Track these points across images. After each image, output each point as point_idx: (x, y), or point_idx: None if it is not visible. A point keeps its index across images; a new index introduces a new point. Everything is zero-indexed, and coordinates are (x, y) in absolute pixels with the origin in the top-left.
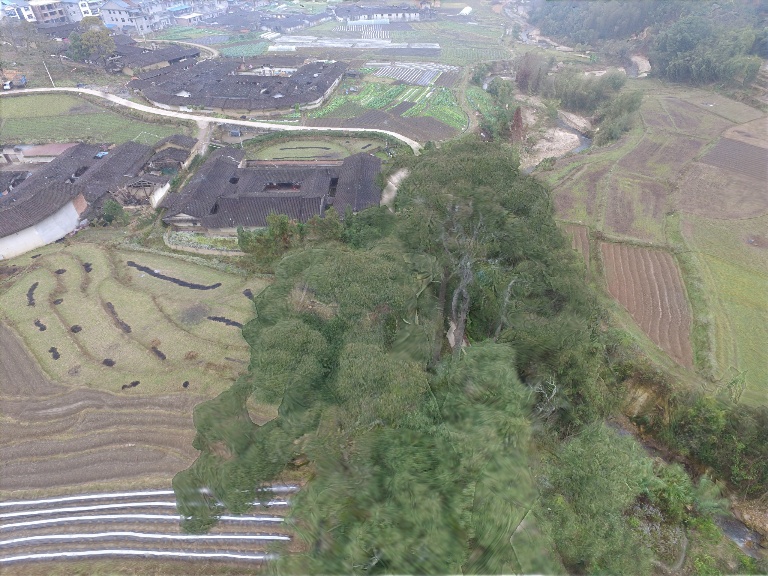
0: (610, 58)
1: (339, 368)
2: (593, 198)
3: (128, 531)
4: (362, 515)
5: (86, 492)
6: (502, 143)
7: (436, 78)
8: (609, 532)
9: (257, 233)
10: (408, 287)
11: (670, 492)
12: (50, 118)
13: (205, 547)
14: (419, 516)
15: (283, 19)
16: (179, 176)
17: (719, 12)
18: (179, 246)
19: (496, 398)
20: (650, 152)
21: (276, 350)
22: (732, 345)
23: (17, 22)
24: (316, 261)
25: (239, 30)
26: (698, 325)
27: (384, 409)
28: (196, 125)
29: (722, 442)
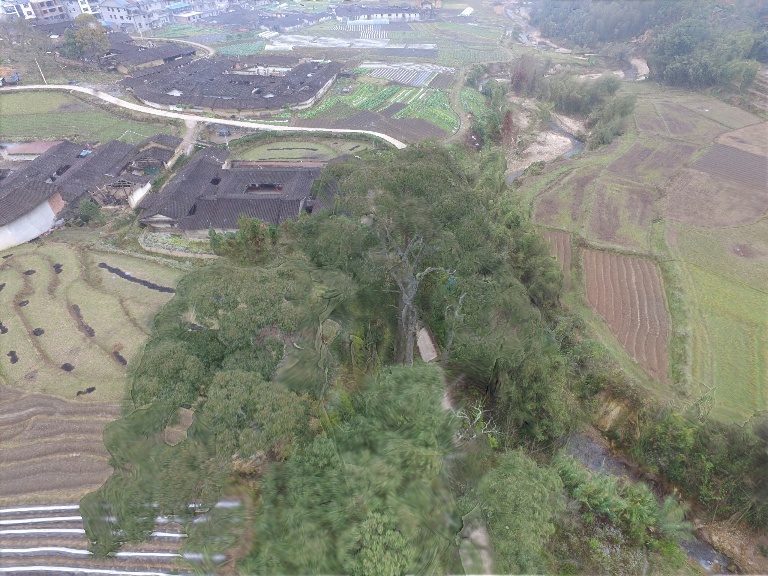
0: (609, 61)
1: (216, 397)
2: (579, 204)
3: (60, 546)
4: (255, 549)
5: (23, 504)
6: (493, 146)
7: (431, 79)
8: (567, 553)
9: (228, 236)
10: (304, 308)
11: (632, 512)
12: (39, 115)
13: (137, 565)
14: (306, 555)
15: (282, 18)
16: (161, 176)
17: (720, 15)
18: (153, 248)
19: (410, 425)
20: (641, 157)
21: (148, 377)
22: (709, 358)
23: (13, 19)
24: (205, 280)
25: (237, 29)
26: (676, 337)
27: (266, 441)
28: (184, 124)
29: (690, 460)
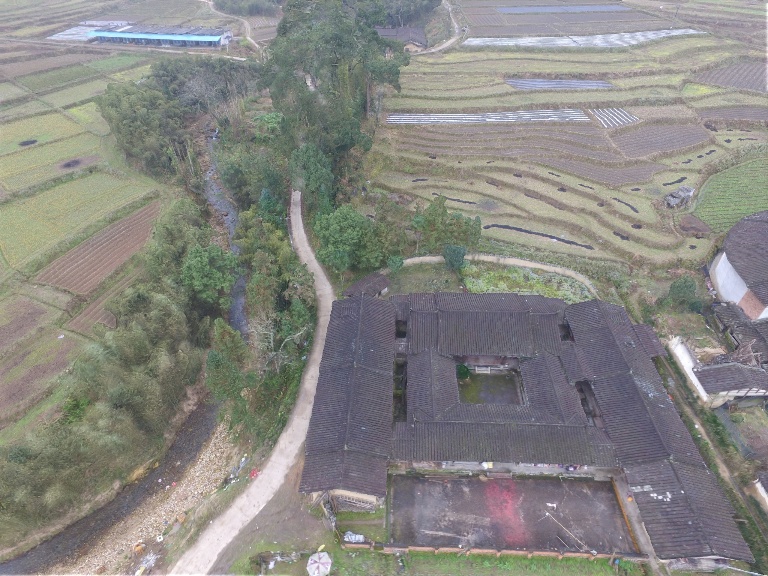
0: None
1: None
2: None
3: (445, 117)
4: None
5: None
6: None
7: None
8: None
9: None
10: None
11: None
12: None
13: (417, 115)
14: None
15: None
16: (734, 452)
17: None
18: None
19: None
20: None
21: None
22: None
23: None
24: None
25: None
26: (117, 216)
27: None
28: None
29: None
